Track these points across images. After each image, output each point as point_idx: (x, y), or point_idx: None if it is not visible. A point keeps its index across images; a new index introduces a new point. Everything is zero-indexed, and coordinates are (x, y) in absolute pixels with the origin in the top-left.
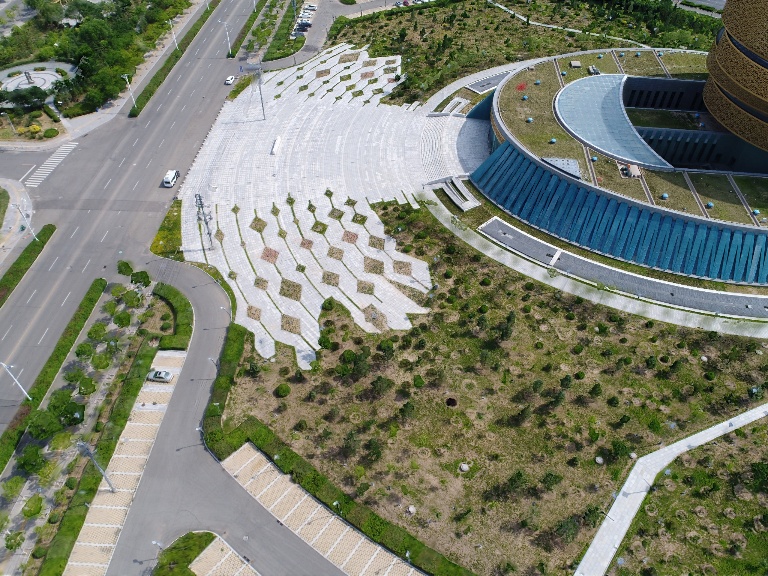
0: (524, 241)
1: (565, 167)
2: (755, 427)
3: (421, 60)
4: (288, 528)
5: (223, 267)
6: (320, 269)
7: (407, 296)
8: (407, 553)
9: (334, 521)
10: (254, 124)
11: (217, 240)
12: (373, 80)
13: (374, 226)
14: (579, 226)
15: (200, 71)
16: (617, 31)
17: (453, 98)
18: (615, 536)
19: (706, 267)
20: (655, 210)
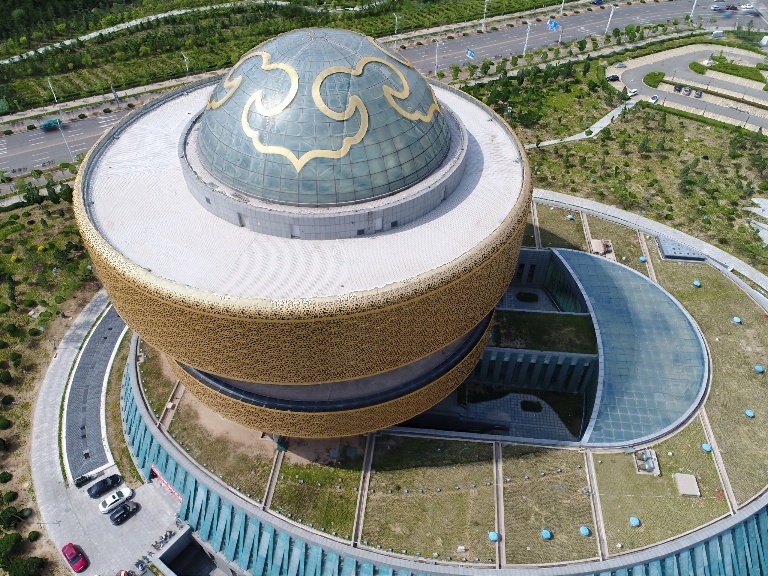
0: None
1: (677, 245)
2: None
3: None
4: (765, 128)
5: None
6: None
7: (767, 219)
8: None
9: None
10: None
11: None
12: None
13: None
14: None
15: None
16: None
17: None
18: None
19: None
20: None
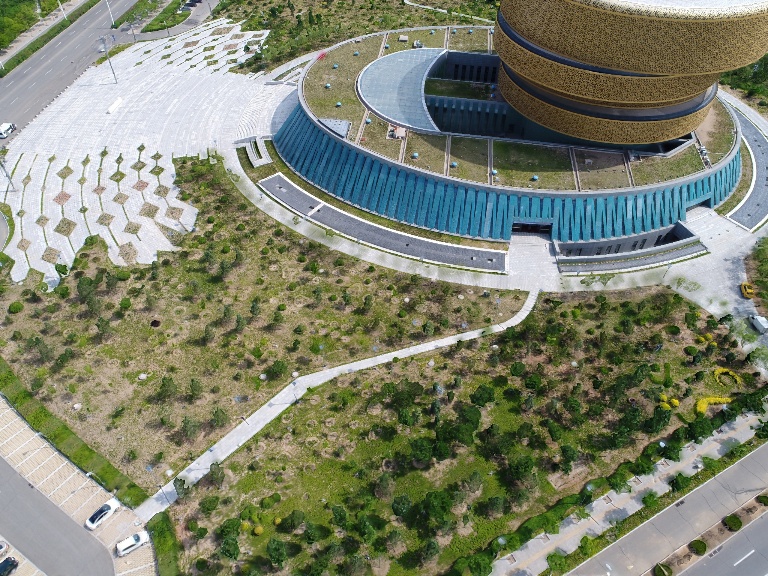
0: (295, 194)
1: (335, 127)
2: (420, 358)
3: (285, 34)
4: None
5: (16, 206)
6: (100, 211)
7: (166, 236)
8: (37, 434)
9: (9, 412)
10: (105, 87)
11: (22, 184)
12: (233, 51)
13: (167, 177)
14: (343, 182)
15: (80, 39)
16: (480, 12)
17: (297, 69)
18: (243, 437)
19: (446, 222)
20: (401, 167)
